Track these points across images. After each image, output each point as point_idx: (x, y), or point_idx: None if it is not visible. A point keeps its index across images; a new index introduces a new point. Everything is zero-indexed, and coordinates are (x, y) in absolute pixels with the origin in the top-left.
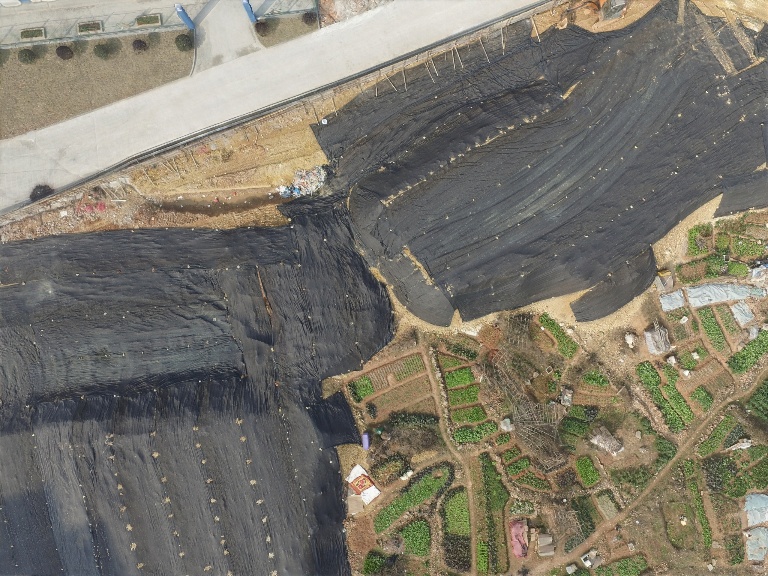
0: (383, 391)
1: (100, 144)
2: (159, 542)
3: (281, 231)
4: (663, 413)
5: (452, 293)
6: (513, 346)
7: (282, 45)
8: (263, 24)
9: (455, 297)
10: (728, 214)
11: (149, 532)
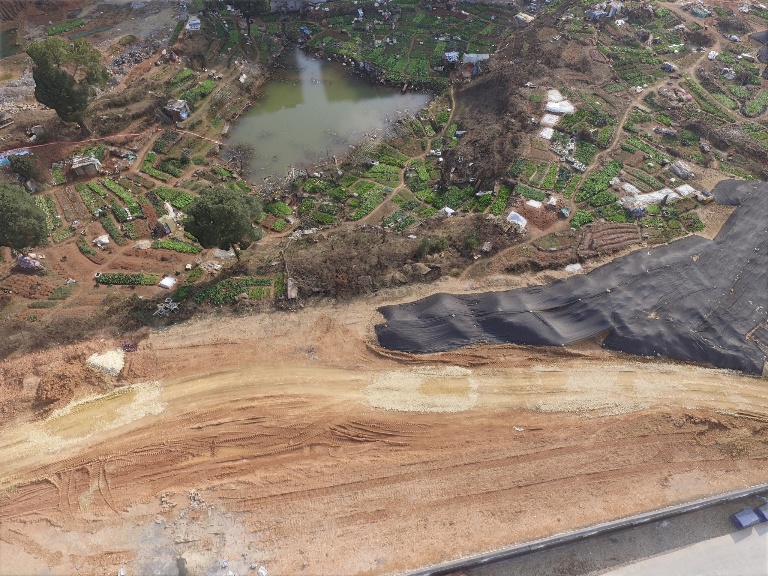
0: None
1: None
2: None
3: None
4: None
5: None
6: None
7: None
8: None
9: None
10: None
11: None
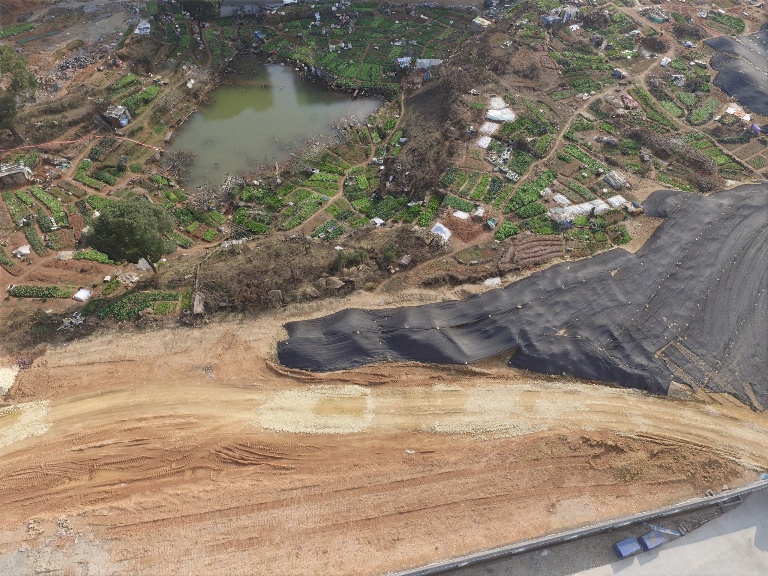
0: (763, 151)
1: None
2: None
3: None
4: None
5: None
6: None
7: None
8: None
9: None
10: None
11: None
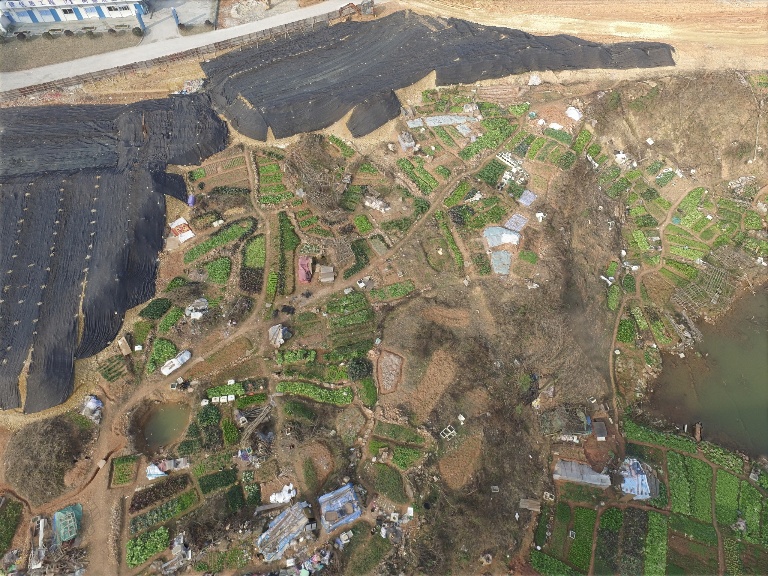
0: (212, 176)
1: (71, 72)
2: (0, 248)
3: (166, 99)
4: (417, 184)
5: (264, 111)
6: (311, 155)
7: (192, 36)
8: (182, 24)
9: (266, 115)
10: (445, 85)
11: None
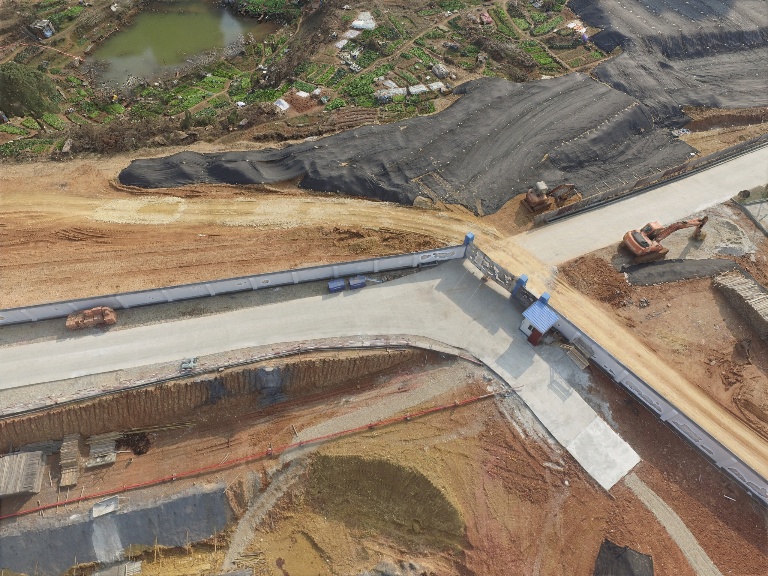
0: None
1: None
2: None
3: (685, 104)
4: None
5: None
6: None
7: None
8: None
9: None
10: None
11: (677, 2)
